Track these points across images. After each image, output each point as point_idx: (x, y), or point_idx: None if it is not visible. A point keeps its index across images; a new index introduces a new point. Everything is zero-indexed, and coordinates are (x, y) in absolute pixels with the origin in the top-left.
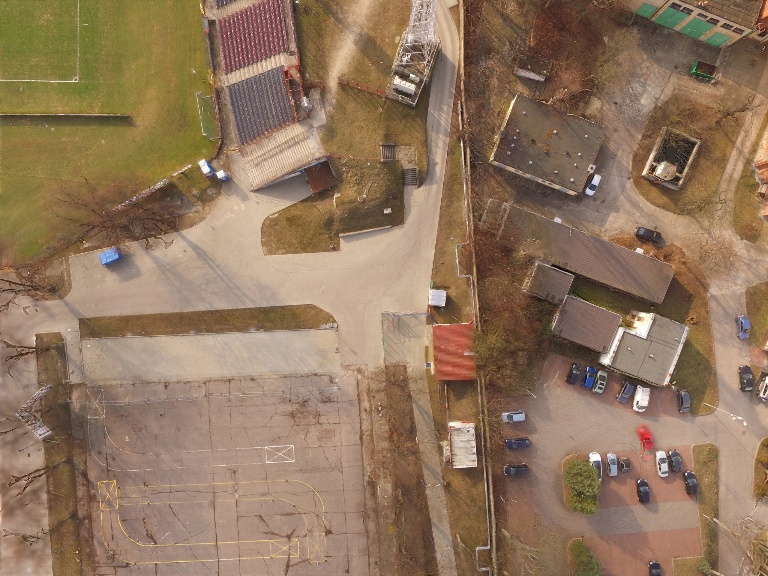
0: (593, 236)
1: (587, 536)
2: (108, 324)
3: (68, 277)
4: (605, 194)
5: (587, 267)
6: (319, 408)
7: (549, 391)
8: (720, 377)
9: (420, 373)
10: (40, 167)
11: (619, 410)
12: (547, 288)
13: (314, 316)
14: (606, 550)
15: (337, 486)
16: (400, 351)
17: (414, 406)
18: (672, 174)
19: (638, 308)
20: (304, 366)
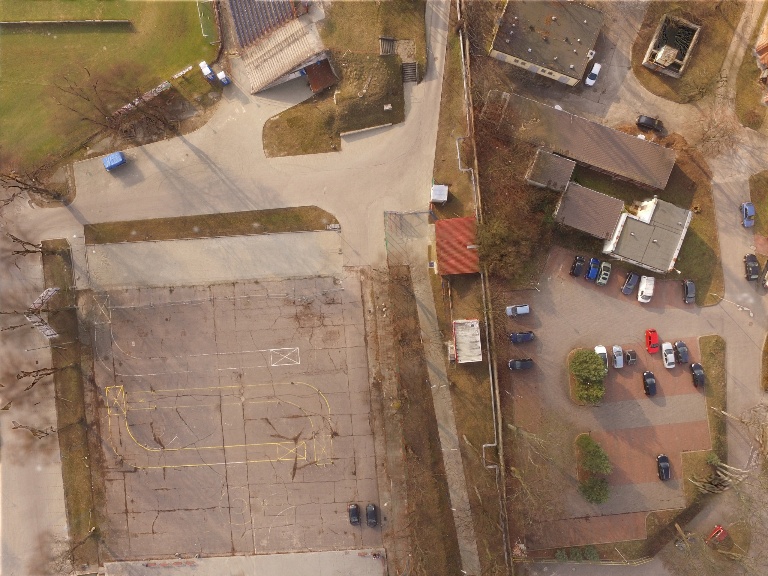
0: (594, 122)
1: (594, 431)
2: (113, 230)
3: (72, 184)
4: (605, 85)
5: (589, 154)
6: (323, 310)
7: (553, 285)
8: (725, 267)
9: (423, 273)
10: (43, 75)
11: (624, 302)
12: (549, 175)
13: (317, 217)
14: (613, 445)
15: (342, 388)
16: (403, 251)
17: (418, 306)
18: (672, 58)
19: (641, 198)
20: (307, 268)
